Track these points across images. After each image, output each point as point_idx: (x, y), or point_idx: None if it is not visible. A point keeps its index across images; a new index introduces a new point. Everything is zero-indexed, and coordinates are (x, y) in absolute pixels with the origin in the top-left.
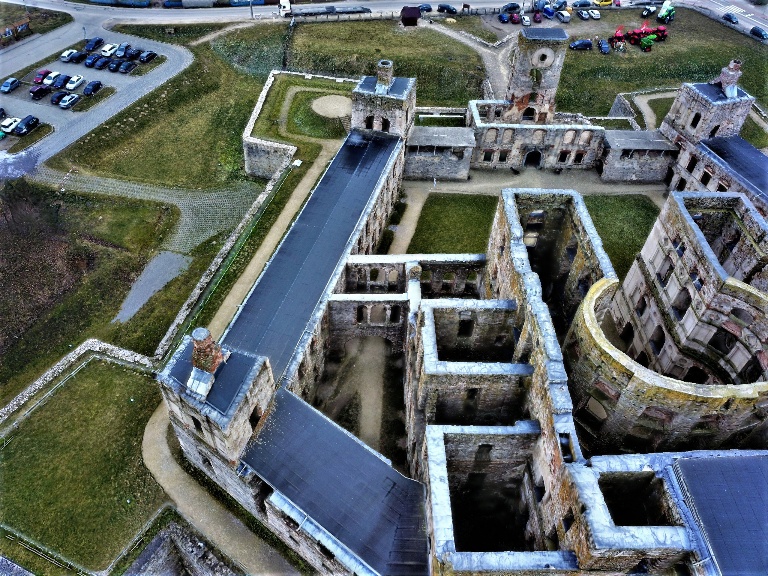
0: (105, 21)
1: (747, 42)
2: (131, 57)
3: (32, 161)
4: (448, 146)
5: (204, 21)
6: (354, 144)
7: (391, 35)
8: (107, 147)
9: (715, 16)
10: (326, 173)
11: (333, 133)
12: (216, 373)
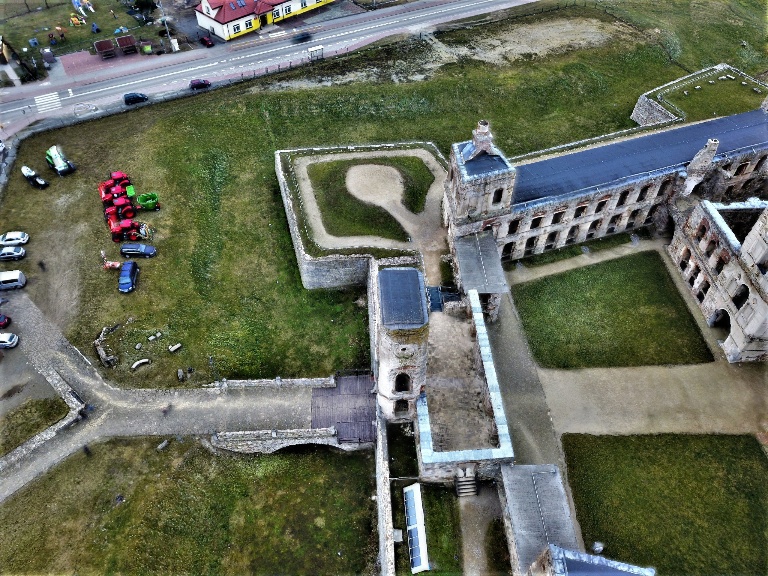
0: None
1: (151, 114)
2: None
3: None
4: None
5: None
6: None
7: None
8: None
9: (66, 120)
10: None
11: None
12: None
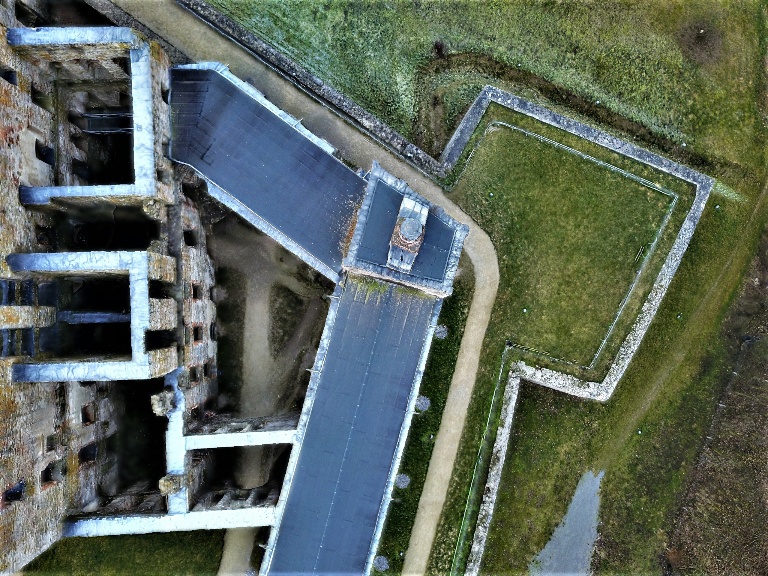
0: None
1: None
2: None
3: None
4: None
5: None
6: None
7: None
8: None
9: None
10: None
11: None
12: None
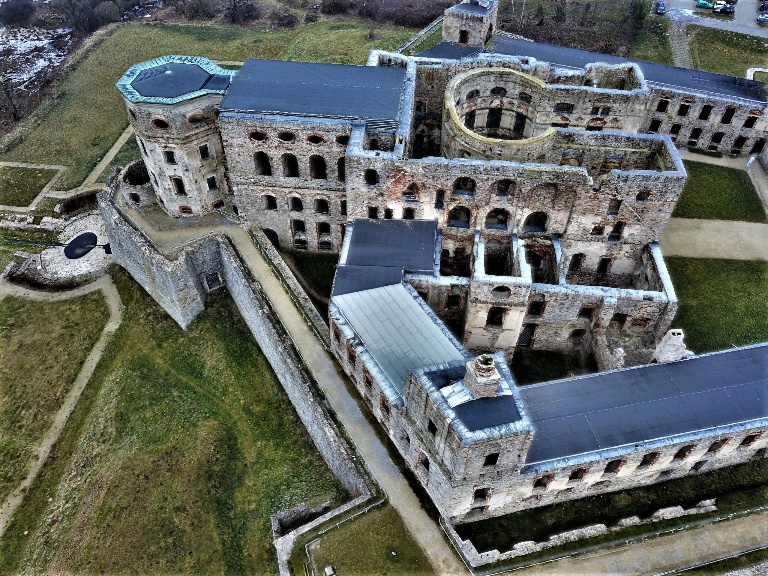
0: None
1: None
2: None
3: (690, 20)
4: None
5: None
6: (738, 81)
7: None
8: (726, 43)
9: None
10: None
11: None
12: (472, 1)
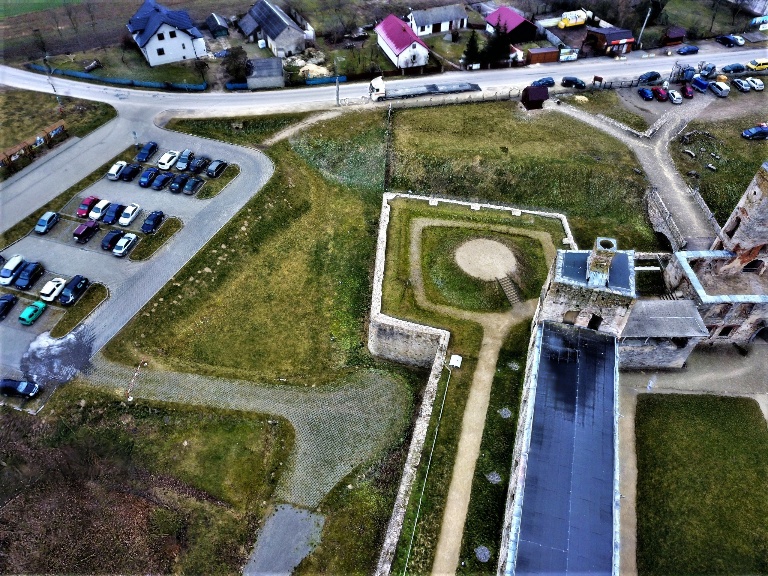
0: (156, 115)
1: None
2: (196, 171)
3: (85, 350)
4: (670, 336)
5: (278, 110)
6: (556, 356)
7: (514, 124)
8: (180, 317)
9: None
10: (533, 420)
11: (491, 303)
12: None
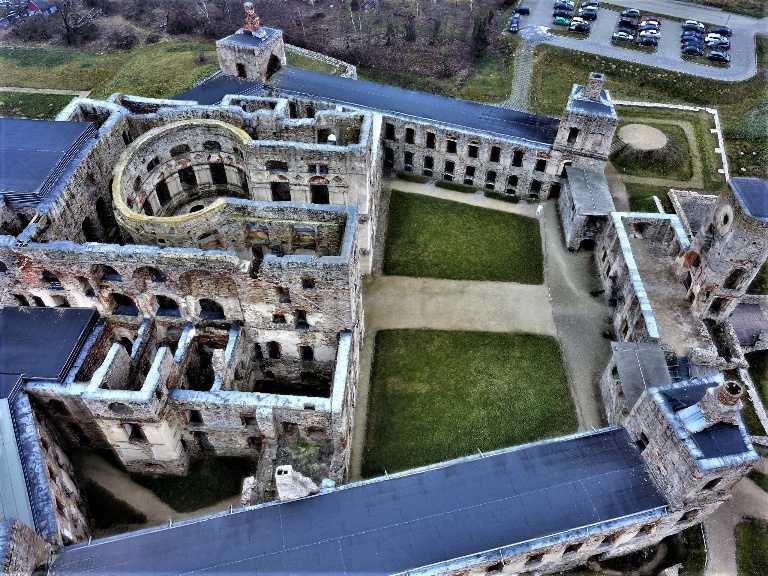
0: None
1: None
2: (709, 49)
3: (541, 39)
4: None
5: None
6: (531, 118)
7: None
8: (574, 64)
9: None
10: None
11: None
12: (245, 31)
